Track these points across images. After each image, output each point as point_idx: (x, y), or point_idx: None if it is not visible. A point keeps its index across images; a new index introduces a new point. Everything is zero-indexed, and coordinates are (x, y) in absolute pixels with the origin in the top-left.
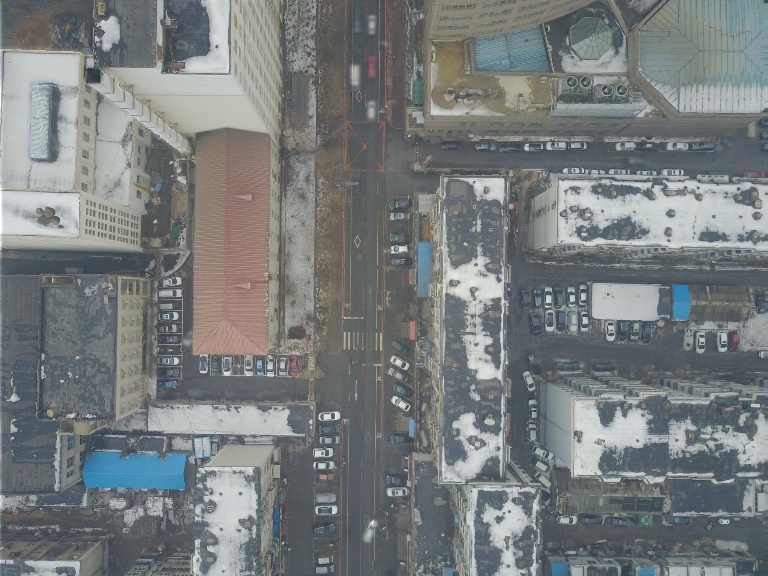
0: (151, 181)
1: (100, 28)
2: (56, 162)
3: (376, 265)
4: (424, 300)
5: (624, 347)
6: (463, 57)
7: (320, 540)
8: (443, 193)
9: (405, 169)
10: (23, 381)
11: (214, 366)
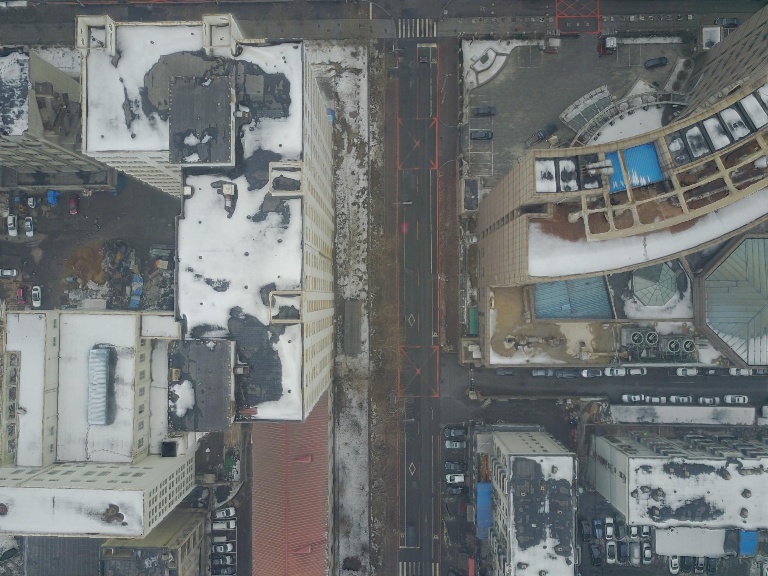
0: None
1: (174, 392)
2: (113, 424)
3: (431, 493)
4: None
5: None
6: (523, 304)
7: None
8: (510, 472)
9: (460, 394)
10: None
11: None
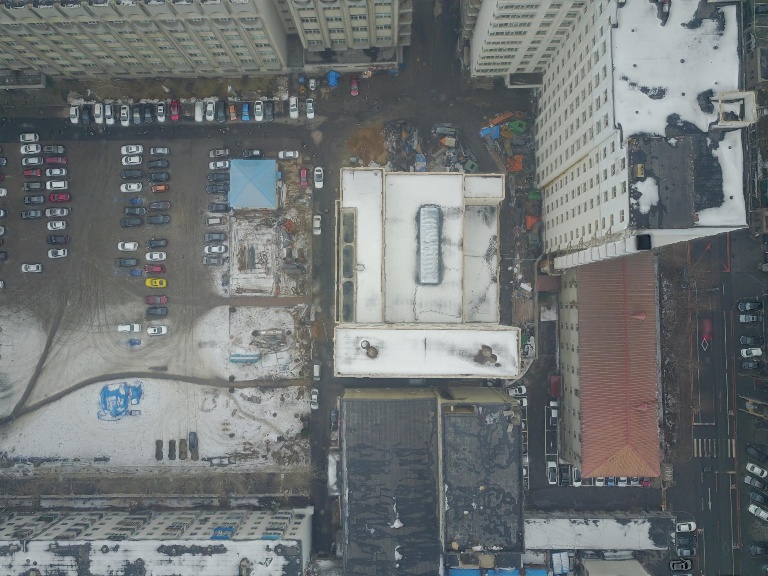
0: None
1: (636, 189)
2: (441, 284)
3: (725, 369)
4: None
5: None
6: None
7: None
8: None
9: (752, 269)
10: (405, 506)
11: (564, 477)
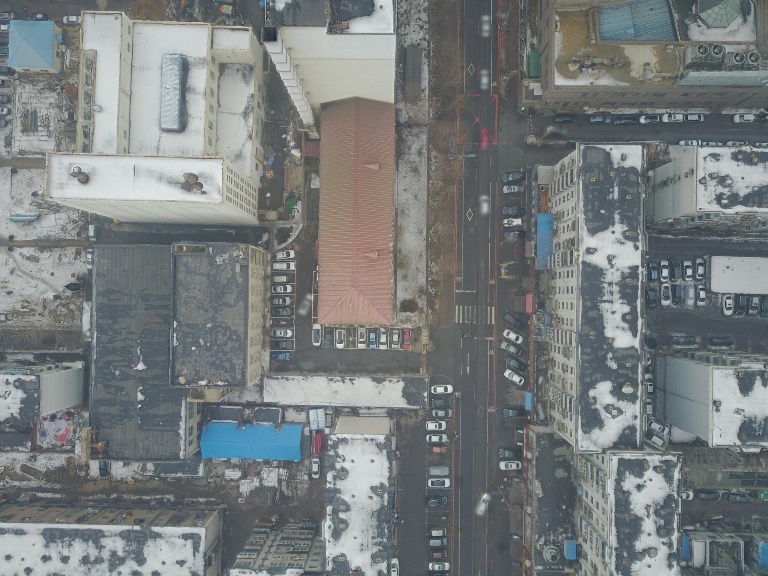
0: (264, 154)
1: None
2: (184, 132)
3: (488, 238)
4: (541, 273)
5: (741, 321)
6: (588, 26)
7: (432, 513)
8: (579, 160)
9: (518, 142)
10: (149, 350)
11: (327, 338)
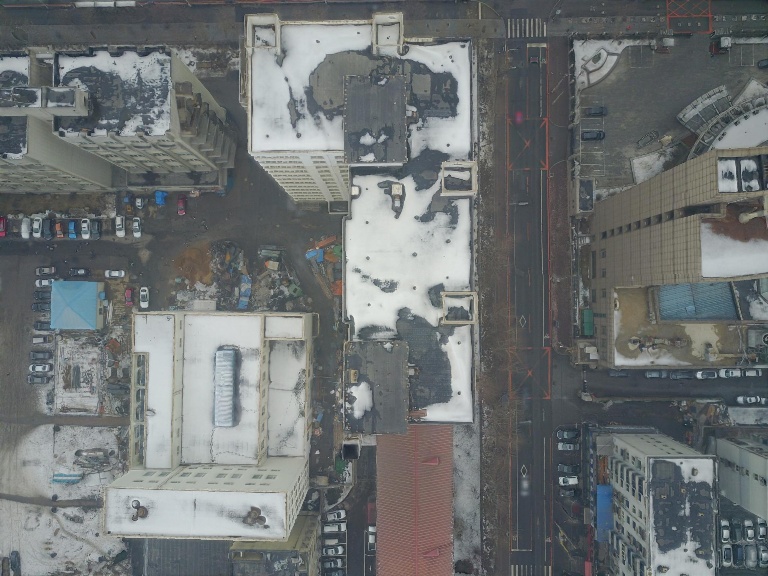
0: (313, 412)
1: (351, 394)
2: (238, 426)
3: (543, 495)
4: None
5: None
6: (647, 305)
7: None
8: (649, 475)
9: (572, 396)
10: None
11: None
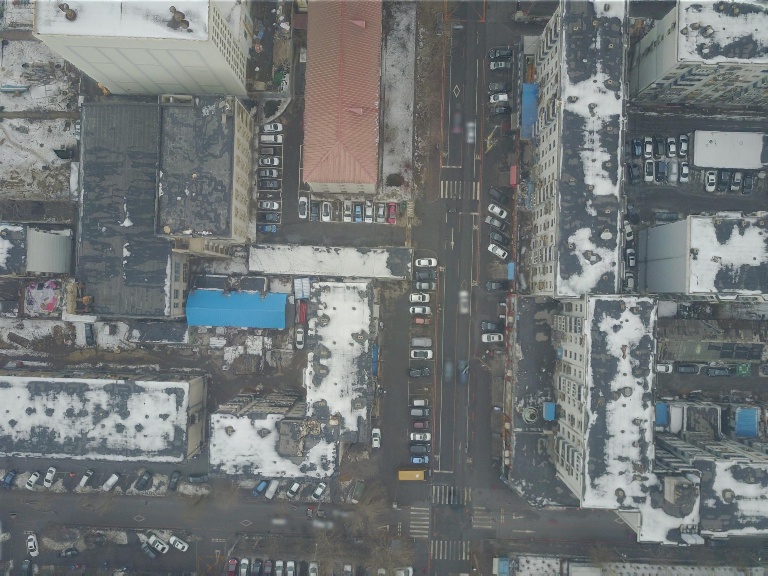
0: (254, 28)
1: None
2: None
3: (475, 115)
4: (525, 144)
5: (724, 198)
6: None
7: (415, 384)
8: (563, 10)
9: (506, 19)
10: (136, 207)
11: (313, 211)
